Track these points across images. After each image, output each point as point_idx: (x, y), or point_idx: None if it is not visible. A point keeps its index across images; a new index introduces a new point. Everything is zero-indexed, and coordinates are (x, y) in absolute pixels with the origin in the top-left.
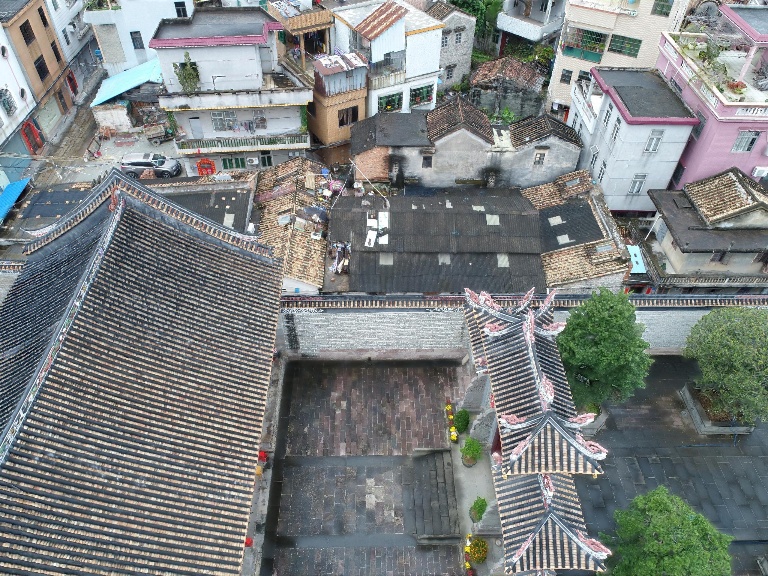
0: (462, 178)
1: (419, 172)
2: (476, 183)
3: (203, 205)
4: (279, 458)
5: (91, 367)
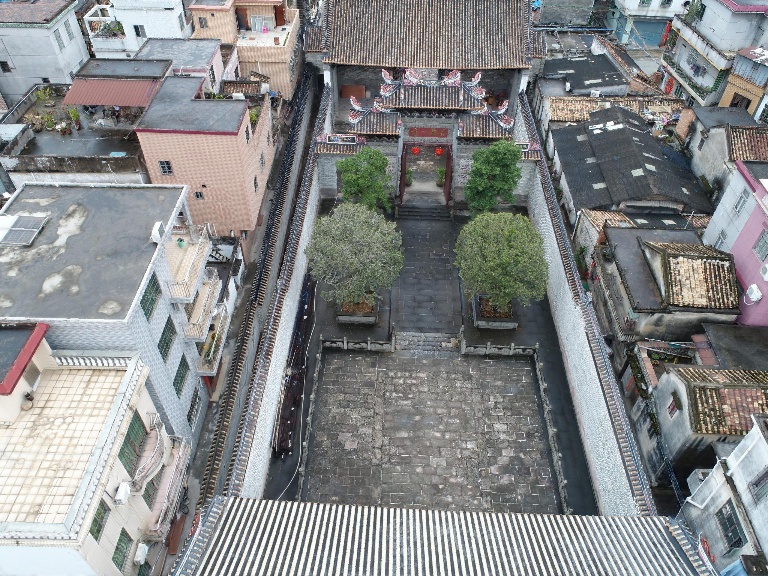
0: (706, 176)
1: (695, 150)
2: (706, 186)
3: (605, 71)
4: None
5: (429, 5)
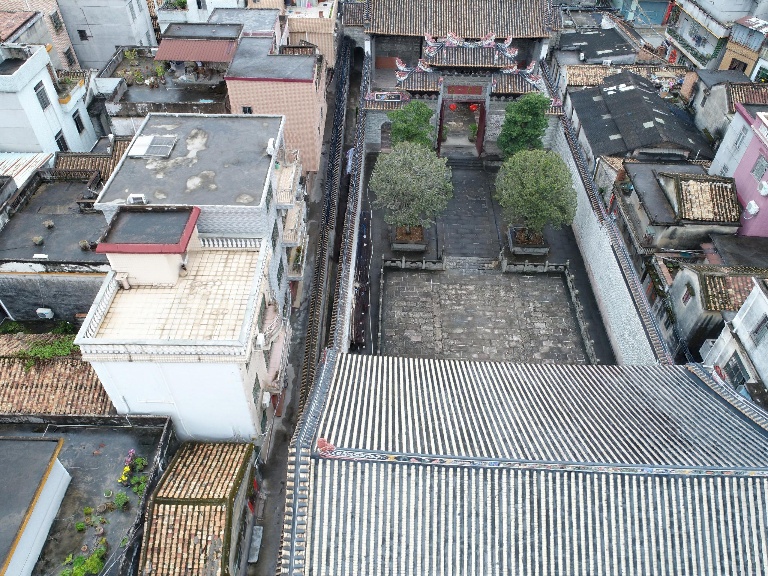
0: (708, 129)
1: (698, 107)
2: (708, 137)
3: (615, 43)
4: (472, 103)
5: None
